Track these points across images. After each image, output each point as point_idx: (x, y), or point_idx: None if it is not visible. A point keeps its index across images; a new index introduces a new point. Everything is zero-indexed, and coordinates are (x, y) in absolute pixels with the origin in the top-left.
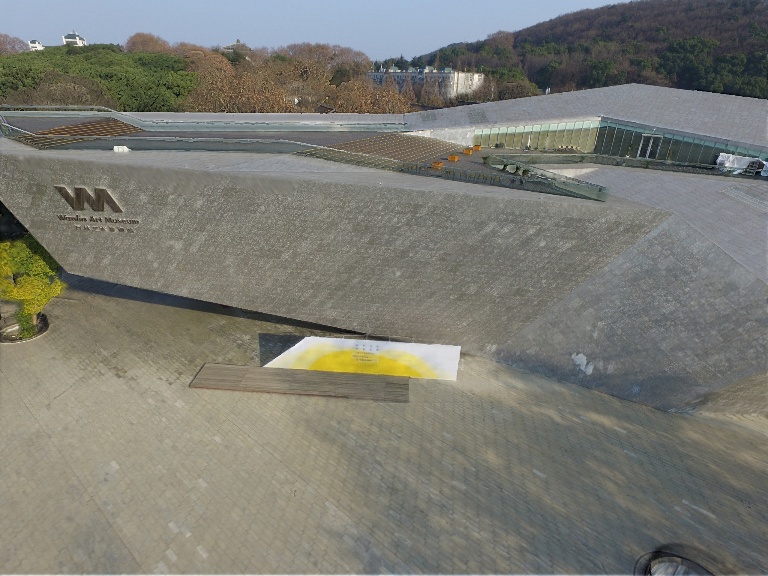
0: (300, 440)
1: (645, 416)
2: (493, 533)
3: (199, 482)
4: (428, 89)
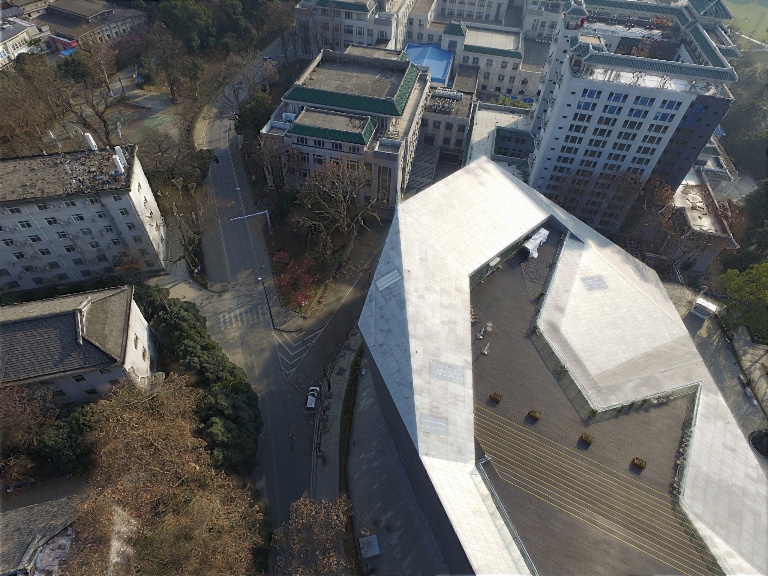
0: None
1: None
2: None
3: None
4: None
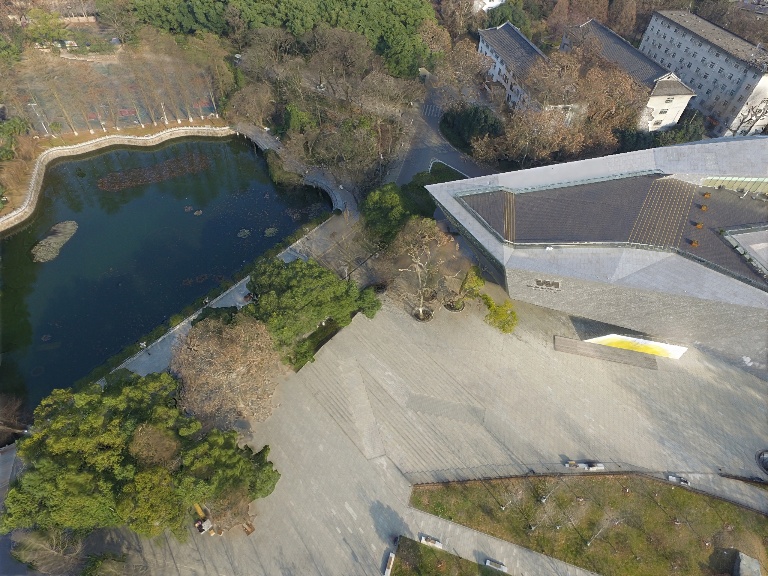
0: (617, 385)
1: None
2: (703, 435)
3: (586, 400)
4: None
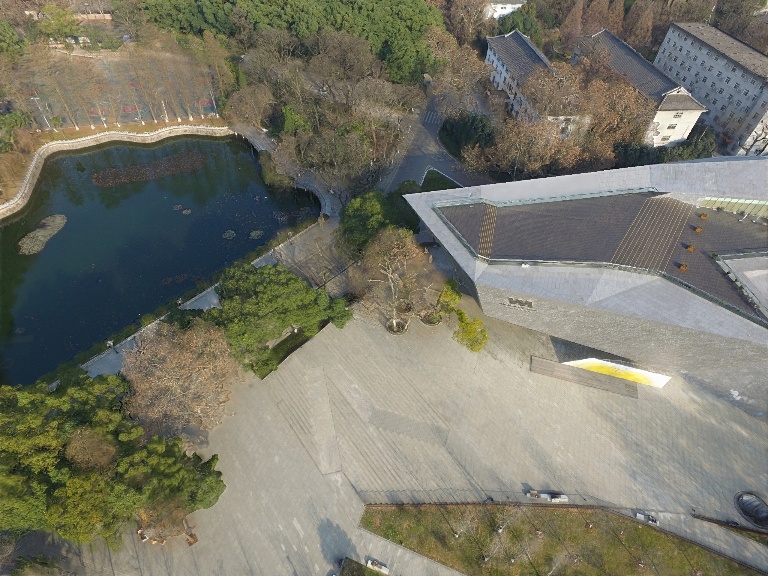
0: (592, 412)
1: (760, 428)
2: (679, 471)
3: (557, 426)
4: (640, 3)
